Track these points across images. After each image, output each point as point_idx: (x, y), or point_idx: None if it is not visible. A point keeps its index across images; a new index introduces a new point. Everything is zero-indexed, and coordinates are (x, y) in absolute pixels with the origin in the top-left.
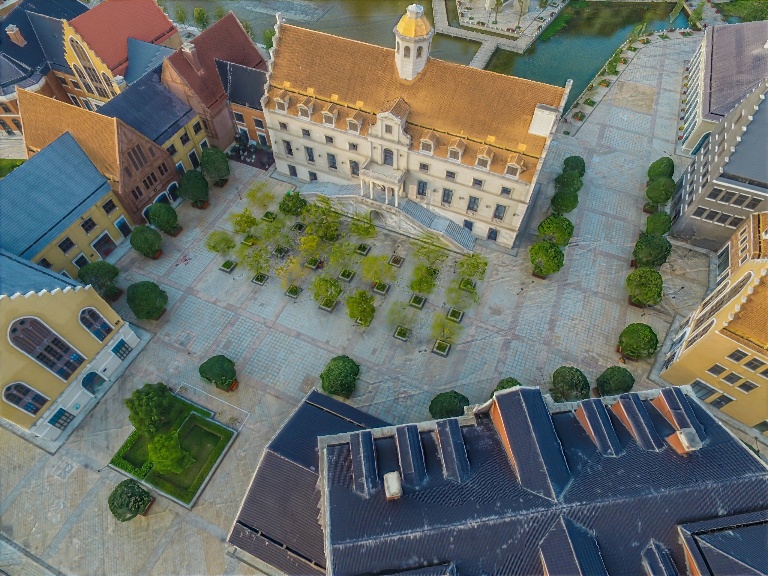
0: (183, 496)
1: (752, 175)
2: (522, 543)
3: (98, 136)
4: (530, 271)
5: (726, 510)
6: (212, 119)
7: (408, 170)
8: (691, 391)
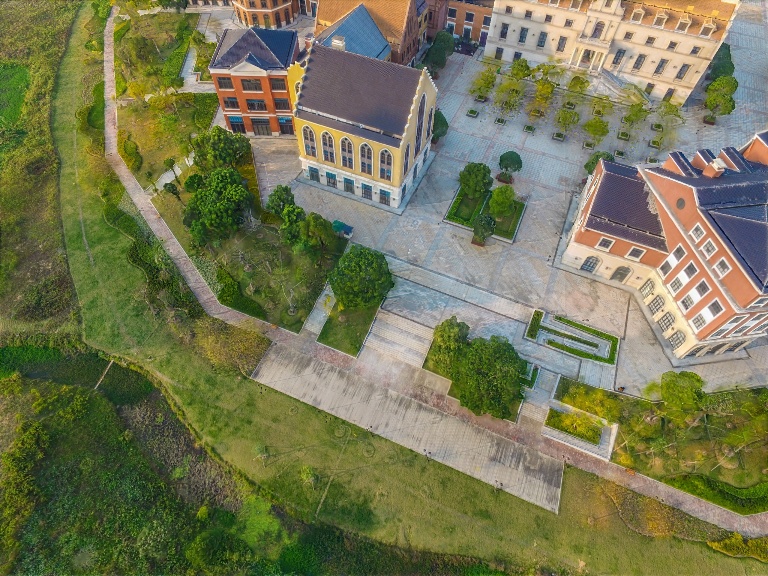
0: (507, 234)
1: None
2: None
3: (391, 6)
4: (701, 120)
5: None
6: (439, 10)
7: (613, 40)
8: None
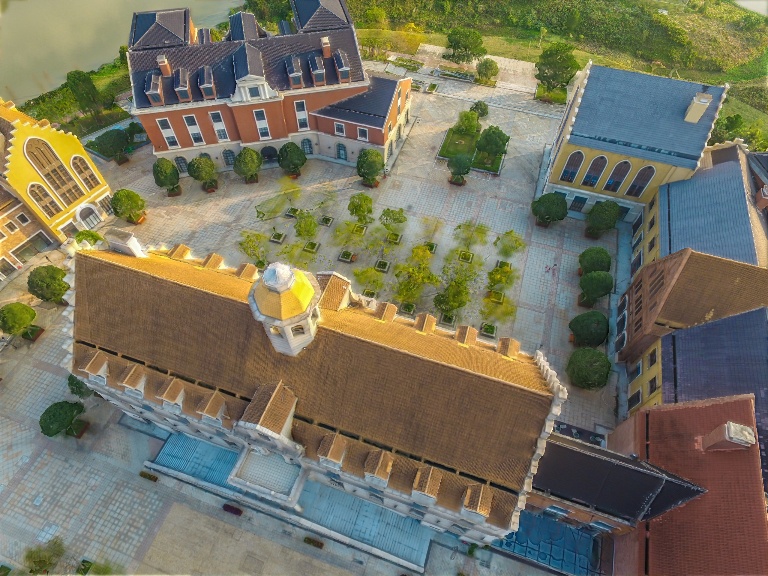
0: None
1: None
2: None
3: None
4: None
5: None
6: None
7: None
8: (133, 110)
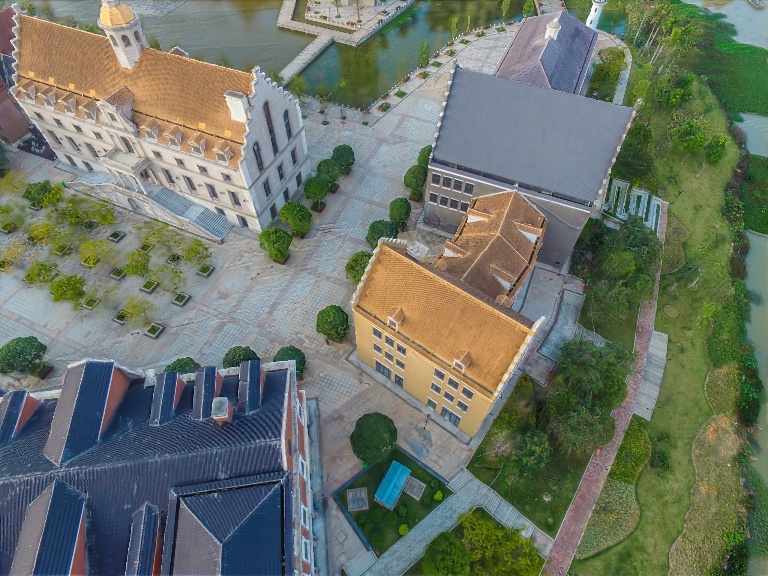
0: None
1: (458, 160)
2: (11, 505)
3: None
4: None
5: (227, 474)
6: None
7: (147, 158)
8: (293, 365)
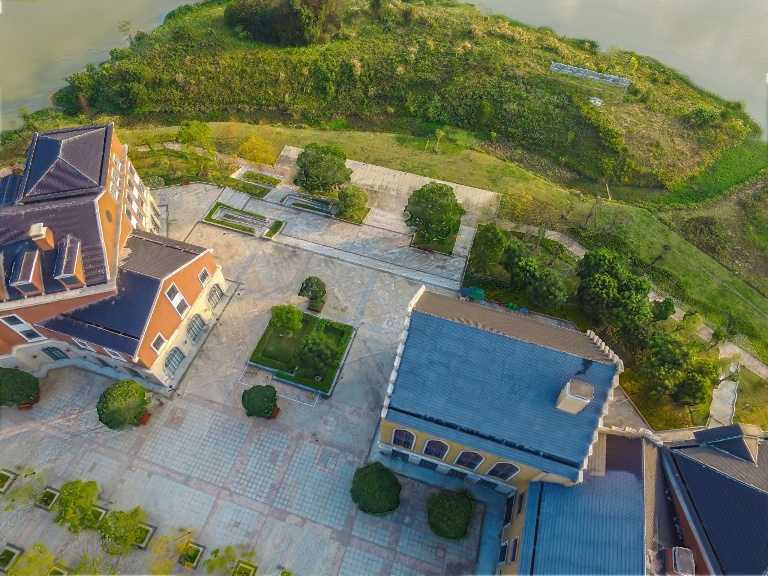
0: None
1: None
2: None
3: None
4: None
5: None
6: None
7: None
8: None
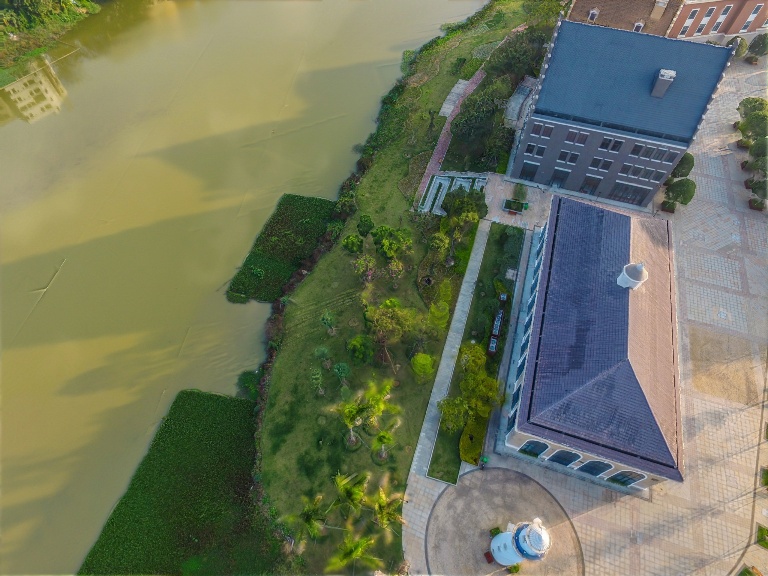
0: None
1: None
2: None
3: None
4: None
5: None
6: None
7: None
8: None
